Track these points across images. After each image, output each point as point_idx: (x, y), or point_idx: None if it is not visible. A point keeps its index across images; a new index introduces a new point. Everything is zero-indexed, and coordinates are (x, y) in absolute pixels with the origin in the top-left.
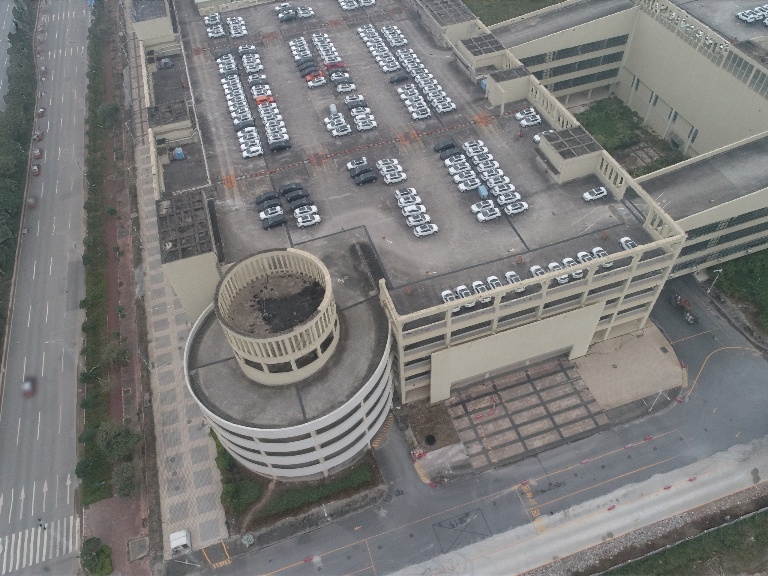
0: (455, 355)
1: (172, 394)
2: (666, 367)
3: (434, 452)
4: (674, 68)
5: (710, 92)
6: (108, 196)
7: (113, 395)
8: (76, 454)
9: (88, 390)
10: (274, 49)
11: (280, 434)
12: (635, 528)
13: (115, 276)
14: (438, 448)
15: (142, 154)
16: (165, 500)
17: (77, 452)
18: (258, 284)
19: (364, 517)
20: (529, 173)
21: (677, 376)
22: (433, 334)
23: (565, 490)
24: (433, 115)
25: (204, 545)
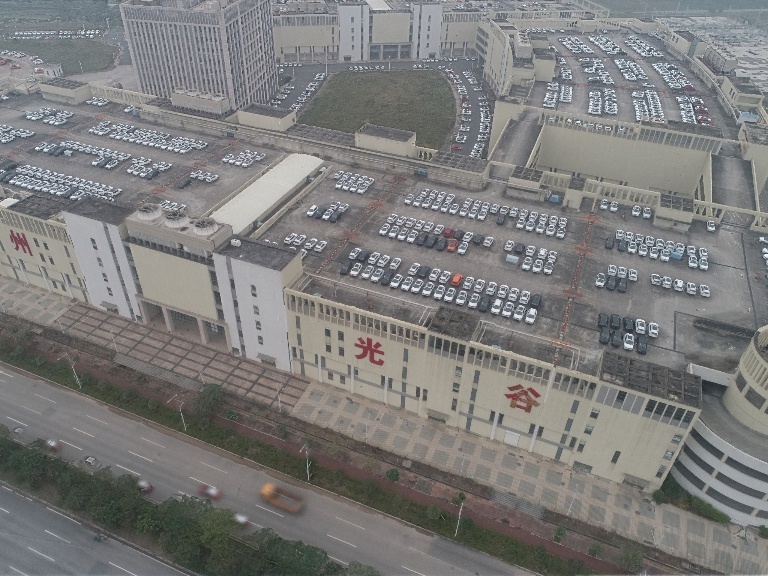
0: None
1: (694, 544)
2: None
3: None
4: (591, 152)
5: (631, 157)
6: (347, 471)
7: None
8: None
9: None
10: (373, 243)
11: None
12: None
13: (488, 521)
14: None
15: (309, 414)
16: None
17: None
18: None
19: None
20: (666, 234)
21: None
22: None
23: None
24: None
25: None
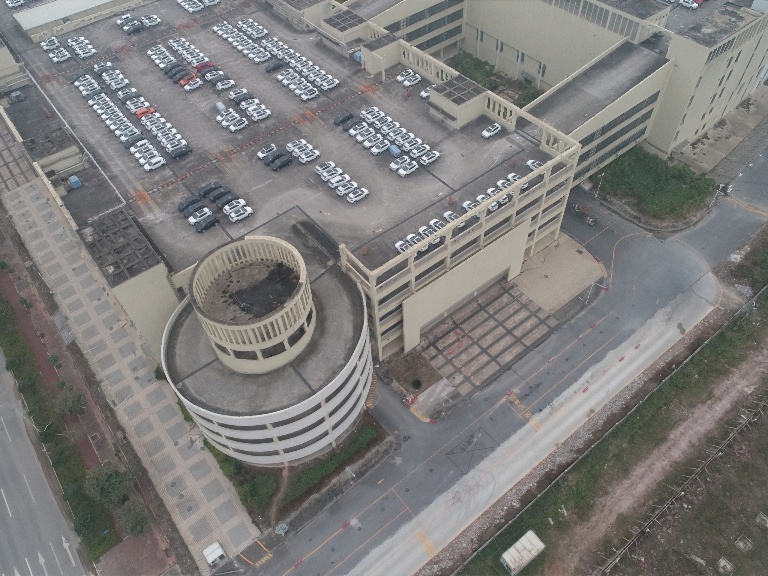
0: (422, 298)
1: (147, 424)
2: (586, 265)
3: (424, 394)
4: (512, 15)
5: (549, 29)
6: None
7: (80, 445)
8: (62, 515)
9: (50, 449)
10: (132, 62)
11: (294, 412)
12: (609, 399)
13: (32, 330)
14: (426, 389)
15: (11, 200)
16: (181, 524)
17: (63, 513)
18: (222, 280)
19: (383, 470)
20: (428, 126)
21: (597, 270)
22: (400, 283)
23: (544, 388)
24: (320, 94)
25: (239, 550)
